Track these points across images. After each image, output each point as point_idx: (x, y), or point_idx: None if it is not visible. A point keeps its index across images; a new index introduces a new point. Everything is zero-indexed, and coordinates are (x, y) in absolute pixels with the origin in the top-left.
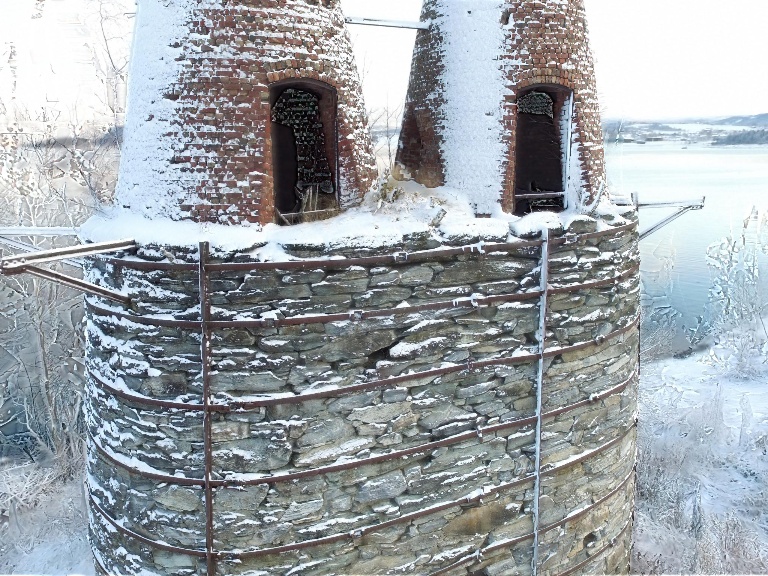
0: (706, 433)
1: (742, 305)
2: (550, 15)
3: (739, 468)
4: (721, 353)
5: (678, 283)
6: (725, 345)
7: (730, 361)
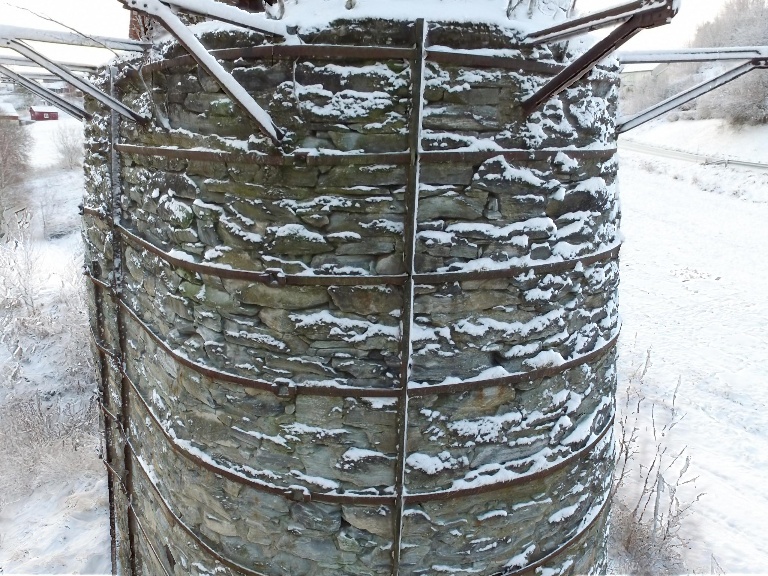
0: None
1: None
2: None
3: None
4: None
5: None
6: None
7: None
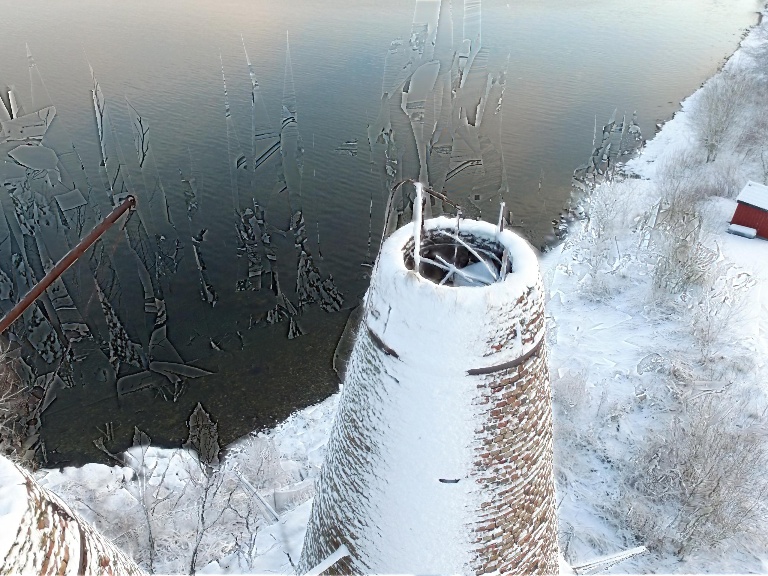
0: (570, 405)
1: (600, 226)
2: (521, 575)
3: (598, 454)
4: (578, 270)
5: (544, 206)
6: (582, 262)
7: (586, 282)
